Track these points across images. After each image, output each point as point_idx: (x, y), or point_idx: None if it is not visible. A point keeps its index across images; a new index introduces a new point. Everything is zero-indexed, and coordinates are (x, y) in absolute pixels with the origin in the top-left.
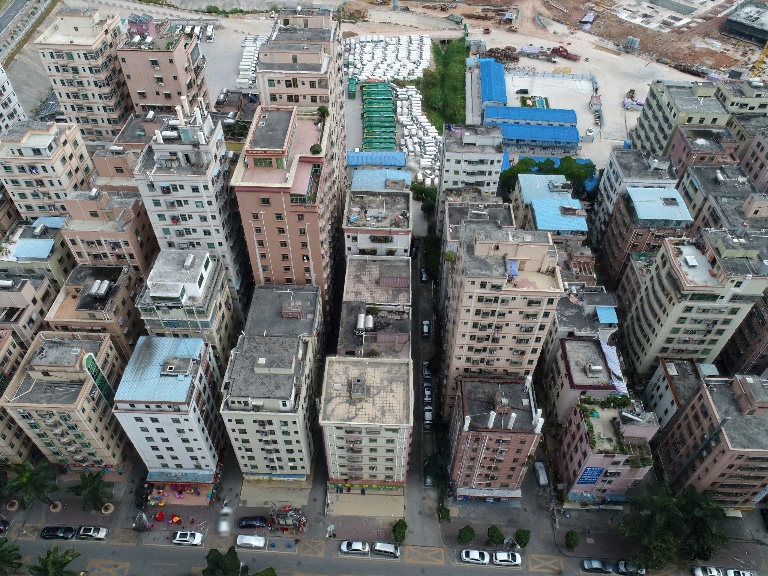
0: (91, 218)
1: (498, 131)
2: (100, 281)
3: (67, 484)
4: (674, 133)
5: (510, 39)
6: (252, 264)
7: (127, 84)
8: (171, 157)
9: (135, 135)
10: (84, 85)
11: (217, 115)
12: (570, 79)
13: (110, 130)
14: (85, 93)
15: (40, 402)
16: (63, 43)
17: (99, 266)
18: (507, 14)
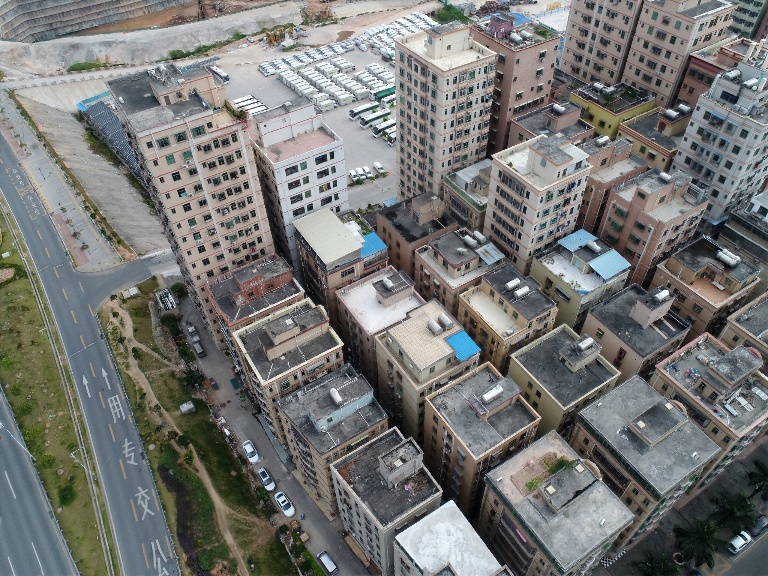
0: (657, 206)
1: (733, 34)
2: (721, 252)
3: (750, 460)
4: (766, 8)
5: None
6: (764, 190)
7: (511, 88)
8: (763, 102)
9: None
10: (471, 105)
11: None
12: (563, 11)
13: (475, 150)
14: (470, 114)
15: None
16: (471, 61)
17: (687, 246)
18: None
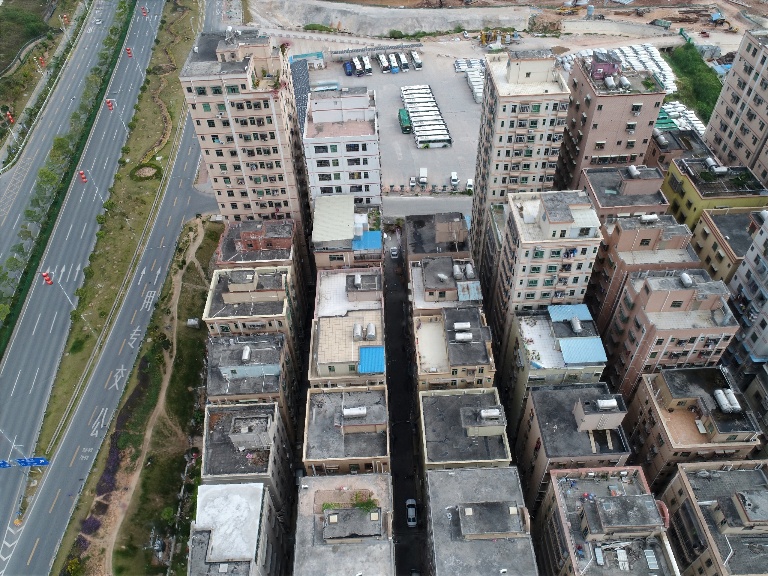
0: (668, 309)
1: None
2: (722, 391)
3: None
4: None
5: (735, 41)
6: None
7: (588, 135)
8: None
9: (607, 195)
10: (534, 140)
11: (687, 162)
12: None
13: (536, 188)
14: (531, 149)
15: (761, 568)
16: None
17: (689, 368)
18: (714, 14)
